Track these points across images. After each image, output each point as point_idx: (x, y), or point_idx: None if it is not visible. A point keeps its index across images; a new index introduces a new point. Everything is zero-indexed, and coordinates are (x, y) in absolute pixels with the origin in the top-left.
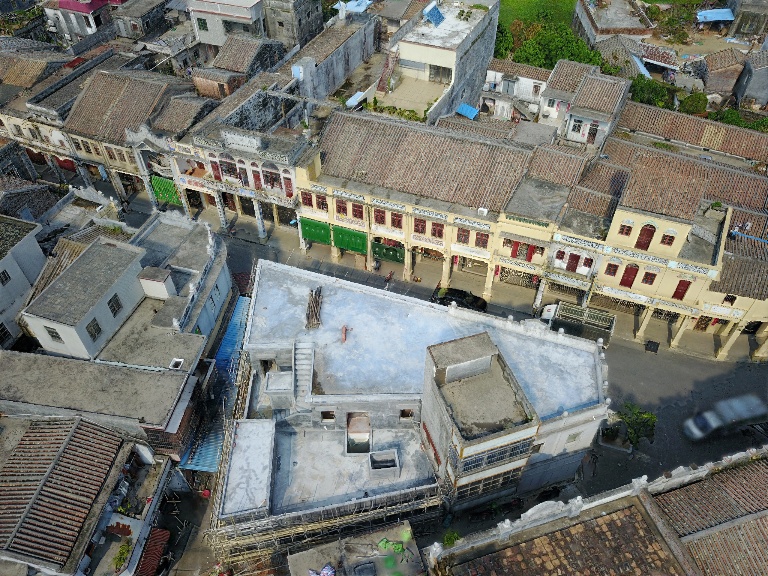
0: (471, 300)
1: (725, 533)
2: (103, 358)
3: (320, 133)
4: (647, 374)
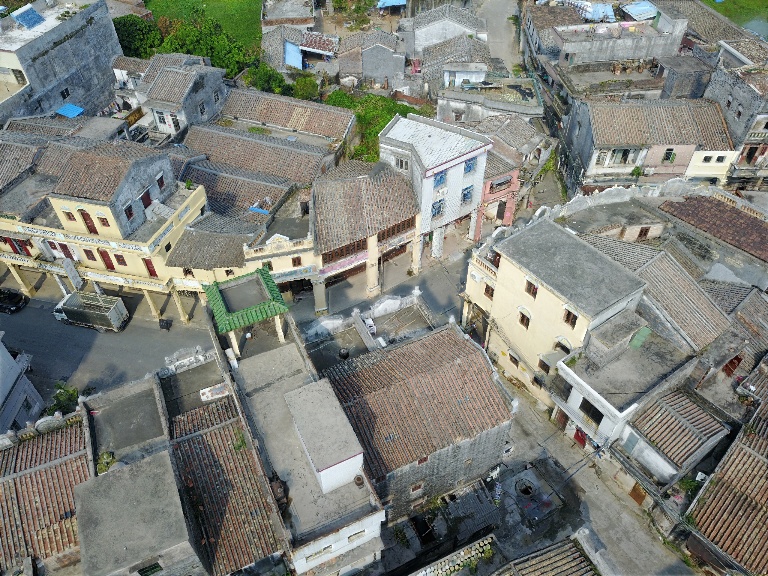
0: (5, 297)
1: None
2: None
3: None
4: (150, 351)
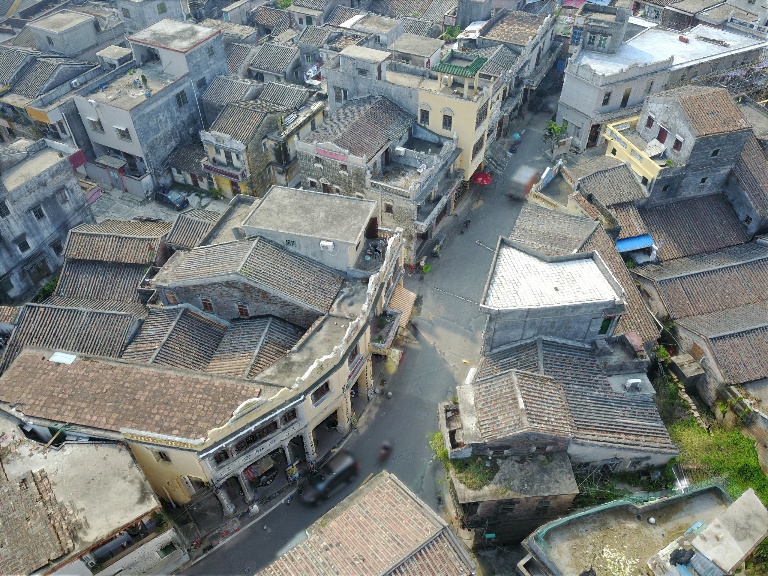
0: None
1: None
2: (725, 5)
3: None
4: None
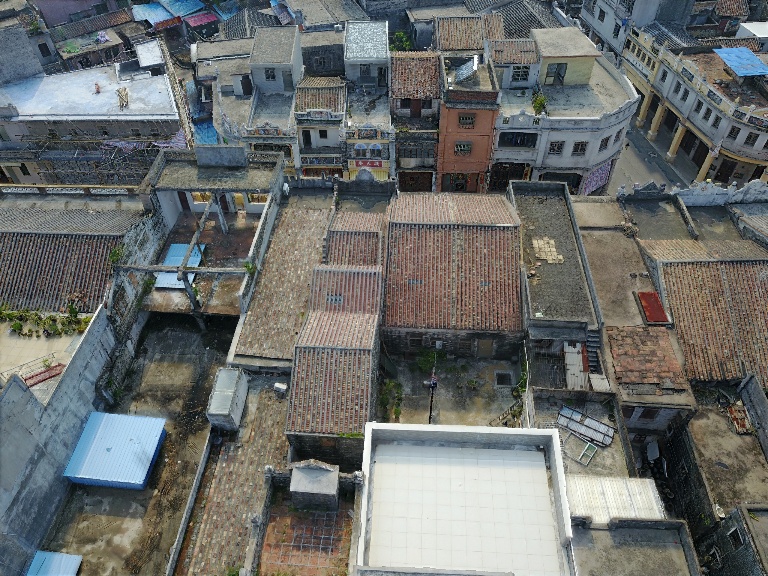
0: None
1: None
2: None
3: (144, 219)
4: None
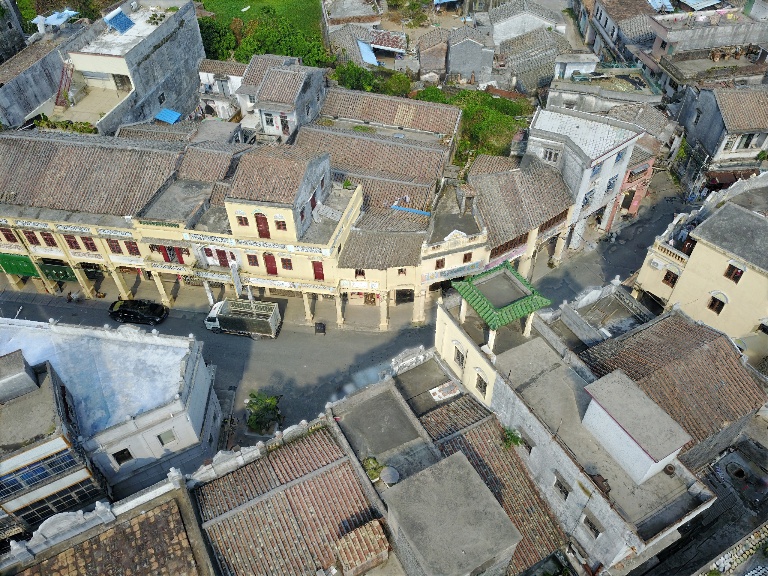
0: (147, 309)
1: (251, 509)
2: None
3: None
4: (312, 356)
